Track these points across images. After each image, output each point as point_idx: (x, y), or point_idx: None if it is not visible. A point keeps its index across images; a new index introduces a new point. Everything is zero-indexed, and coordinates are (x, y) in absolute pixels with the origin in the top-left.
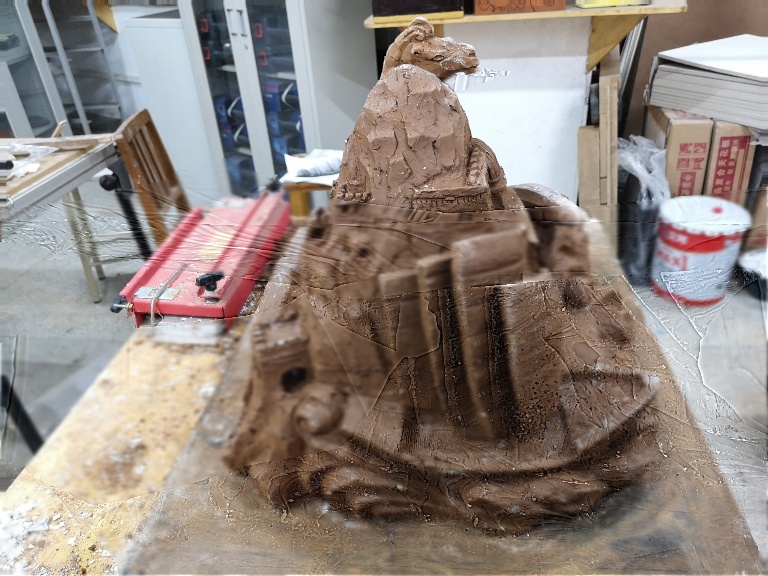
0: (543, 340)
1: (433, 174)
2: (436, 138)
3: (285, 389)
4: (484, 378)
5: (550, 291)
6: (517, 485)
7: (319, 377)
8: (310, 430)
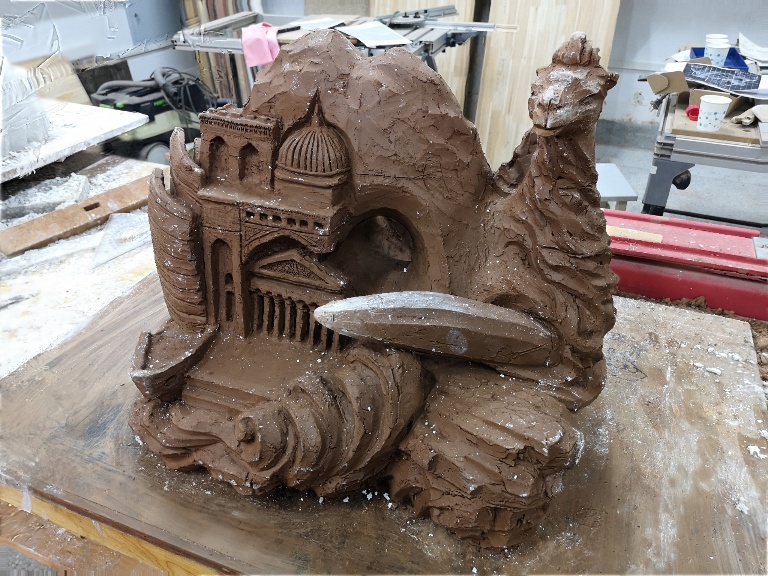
0: None
1: None
2: None
3: None
4: None
5: None
6: None
7: None
8: None
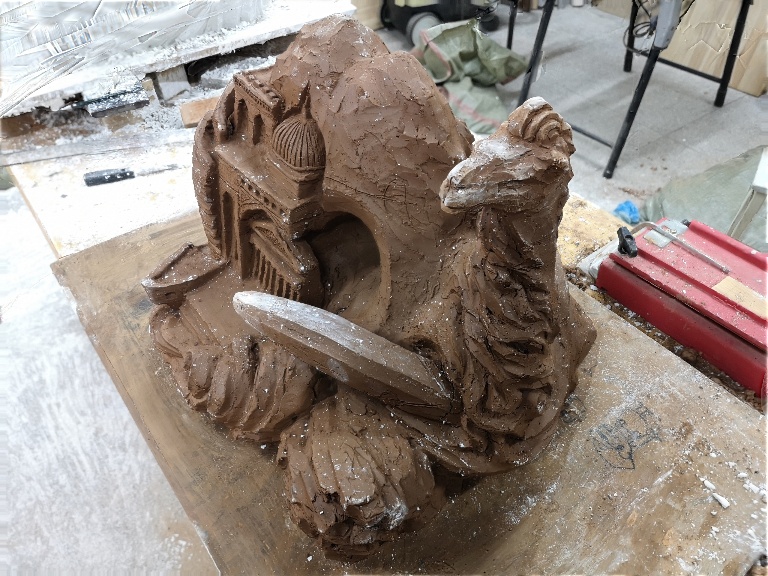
0: None
1: None
2: None
3: None
4: None
5: None
6: None
7: None
8: None
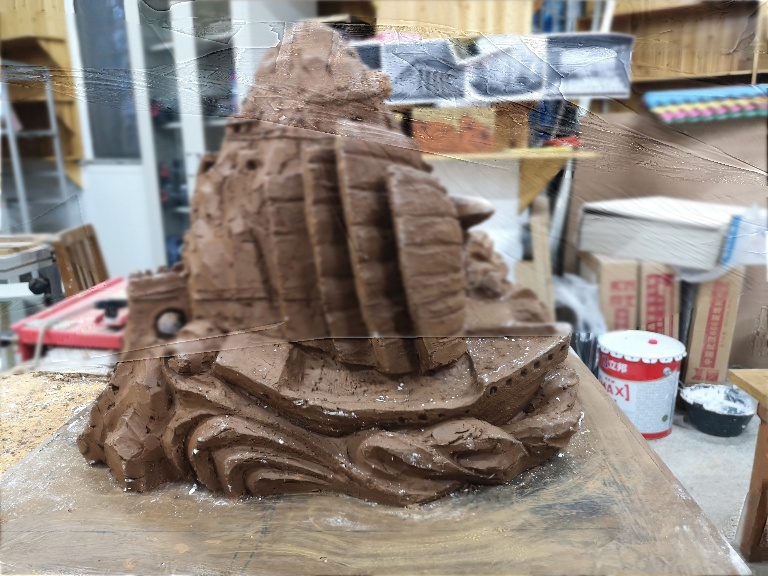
0: (392, 54)
1: None
2: None
3: (85, 40)
4: (321, 63)
5: (404, 32)
6: (340, 109)
7: (130, 40)
8: (102, 59)
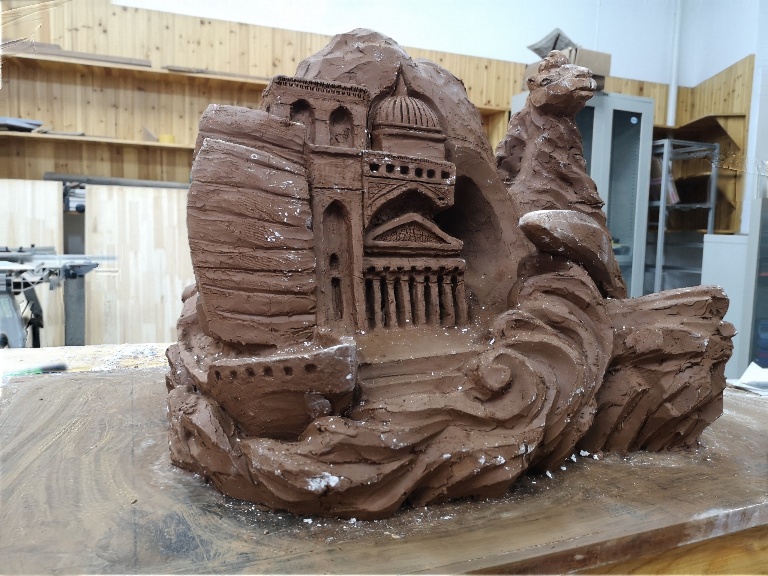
0: None
1: None
2: (312, 62)
3: None
4: None
5: None
6: None
7: None
8: None
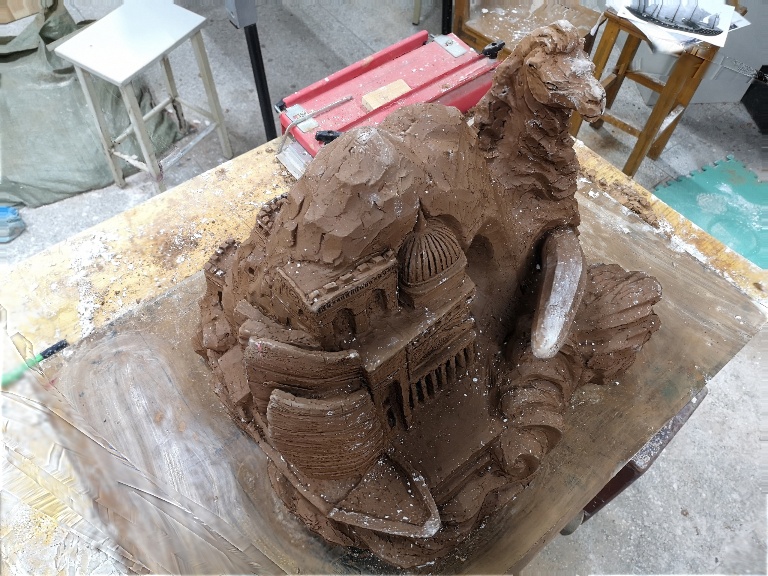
0: None
1: (310, 259)
2: (327, 232)
3: None
4: None
5: None
6: None
7: None
8: None
